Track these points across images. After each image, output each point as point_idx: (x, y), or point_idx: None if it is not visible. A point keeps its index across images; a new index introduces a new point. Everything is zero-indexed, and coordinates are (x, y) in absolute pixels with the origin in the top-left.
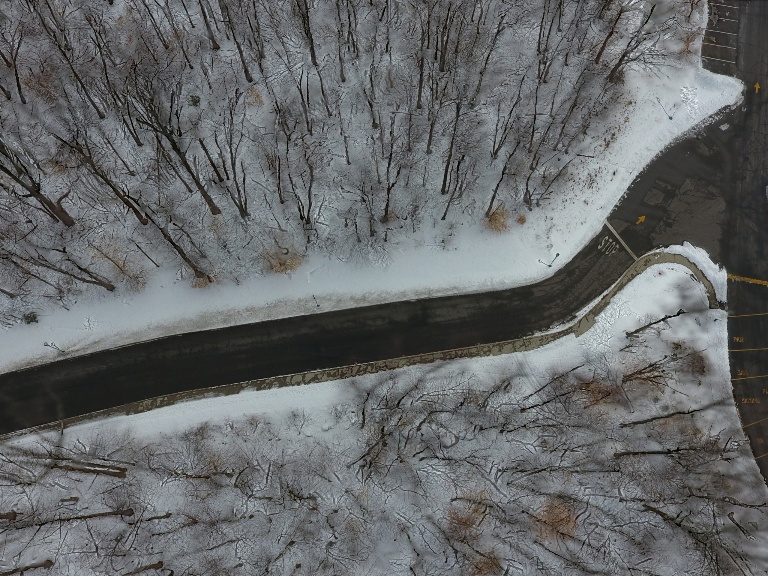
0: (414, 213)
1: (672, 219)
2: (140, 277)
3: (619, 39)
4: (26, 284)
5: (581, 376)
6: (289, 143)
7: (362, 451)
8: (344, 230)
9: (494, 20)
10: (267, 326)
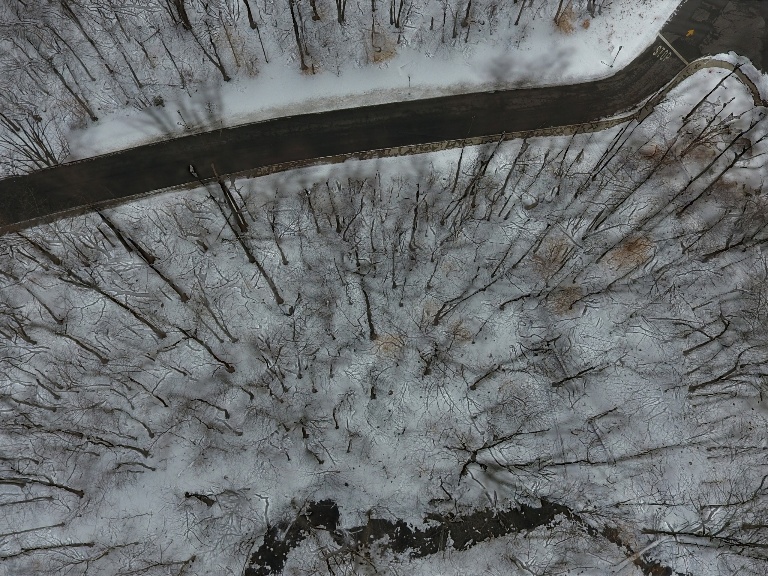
0: (492, 13)
1: (718, 33)
2: (254, 66)
3: None
4: (154, 74)
5: (644, 151)
6: None
7: None
8: None
9: None
10: (365, 111)
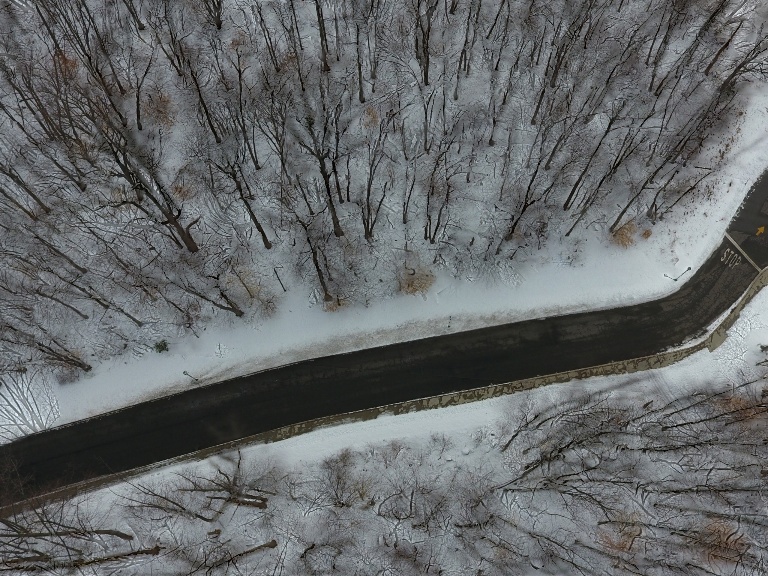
0: (542, 230)
1: None
2: (270, 302)
3: (725, 50)
4: (155, 312)
5: (720, 392)
6: (407, 163)
7: (510, 475)
8: (470, 249)
9: (600, 35)
10: (398, 348)
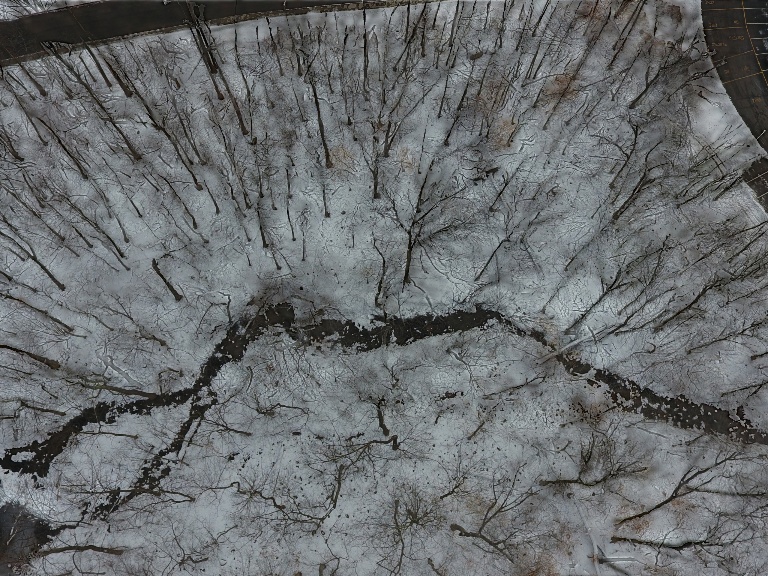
0: None
1: None
2: None
3: None
4: None
5: (581, 11)
6: None
7: None
8: None
9: None
10: None
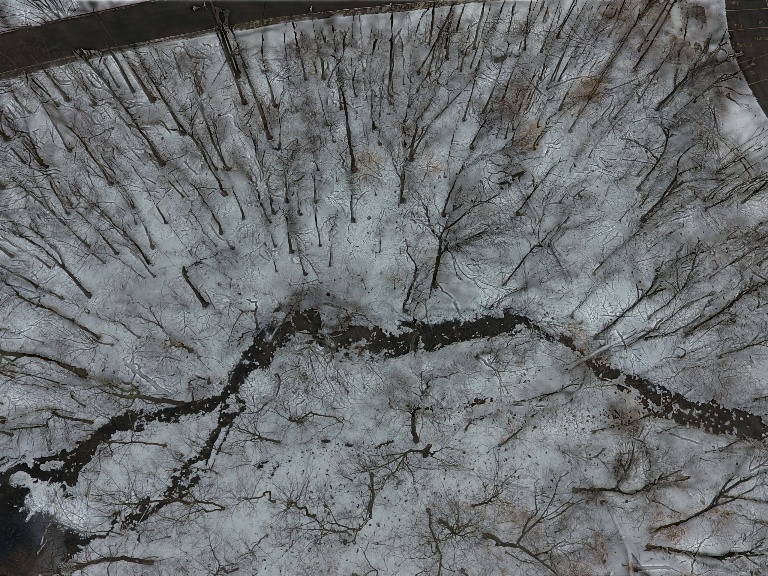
0: None
1: None
2: None
3: None
4: None
5: (605, 13)
6: None
7: None
8: None
9: None
10: None
